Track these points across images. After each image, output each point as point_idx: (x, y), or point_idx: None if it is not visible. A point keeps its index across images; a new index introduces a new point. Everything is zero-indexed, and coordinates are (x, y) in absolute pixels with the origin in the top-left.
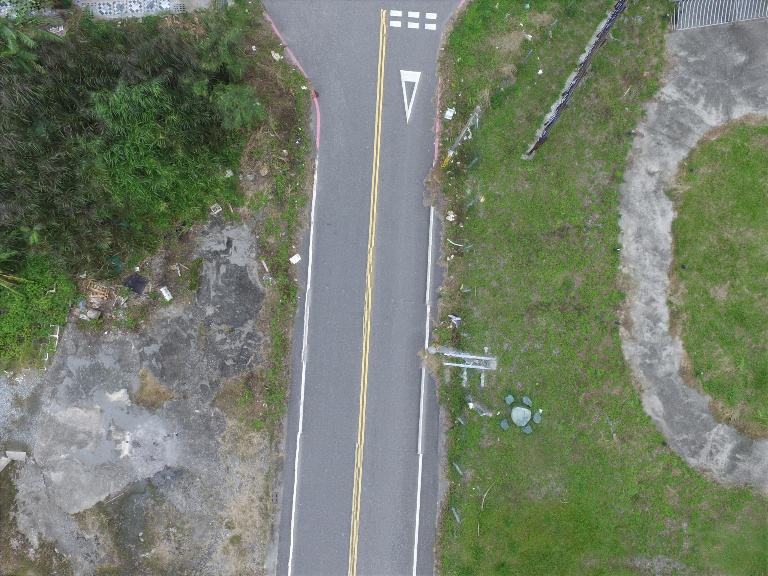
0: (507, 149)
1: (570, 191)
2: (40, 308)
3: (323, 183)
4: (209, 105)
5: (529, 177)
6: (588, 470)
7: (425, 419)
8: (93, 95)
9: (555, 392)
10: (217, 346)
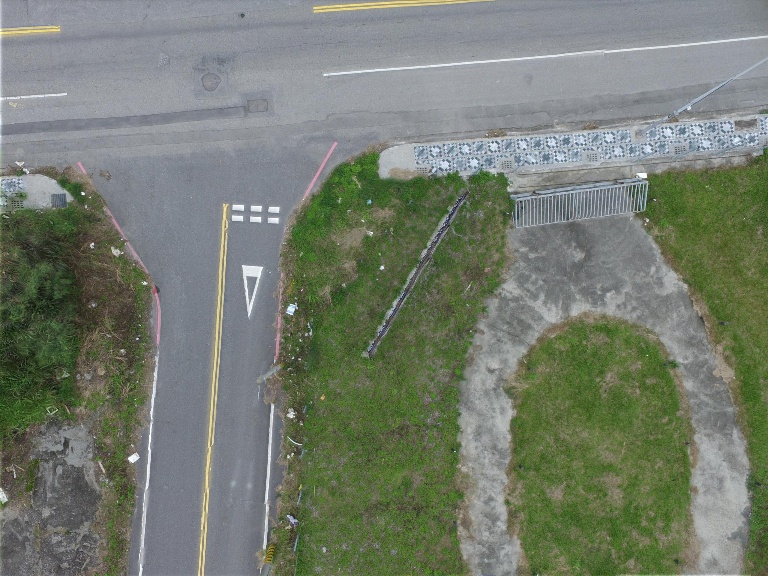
0: (348, 346)
1: (410, 389)
2: None
3: (163, 380)
4: (31, 323)
5: (369, 374)
6: None
7: None
8: None
9: None
10: (52, 549)
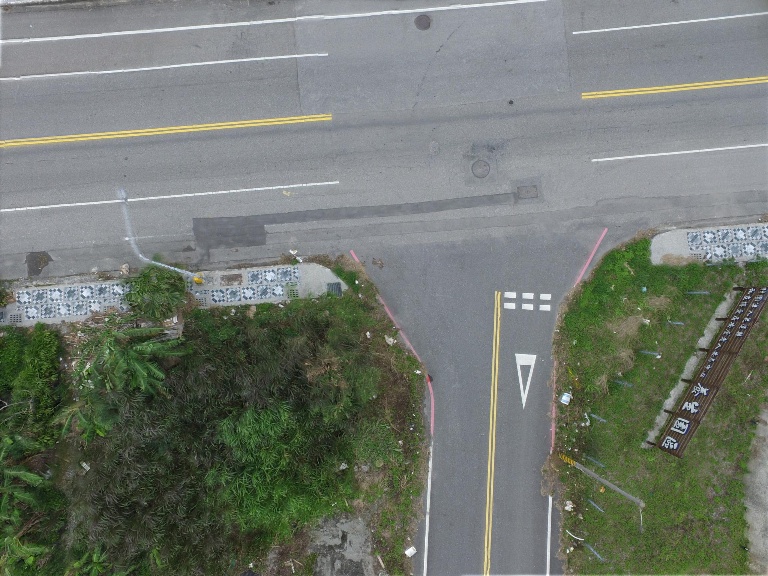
0: (626, 437)
1: (693, 482)
2: None
3: (438, 471)
4: (334, 421)
5: (650, 466)
6: None
7: None
8: (221, 425)
9: None
10: None
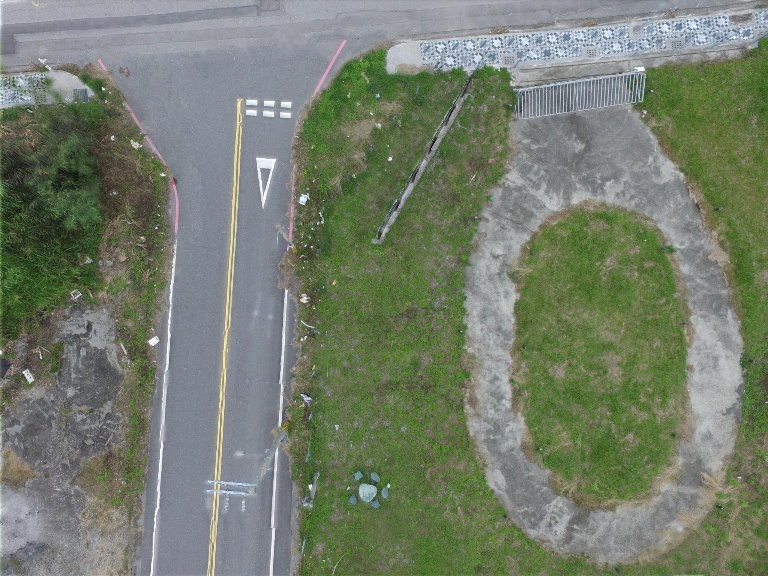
0: (358, 234)
1: (417, 274)
2: None
3: (181, 267)
4: (57, 202)
5: (379, 261)
6: (434, 542)
7: (278, 494)
8: None
9: (403, 467)
10: (77, 426)
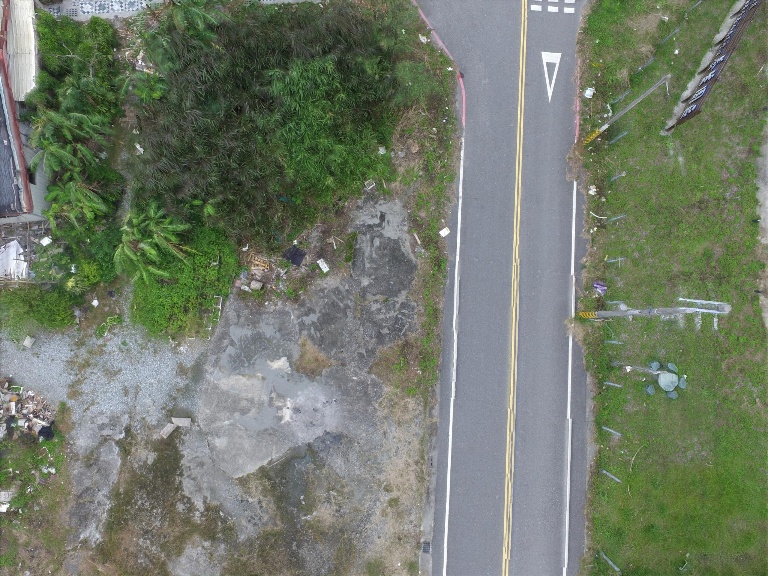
0: (646, 126)
1: (709, 165)
2: (207, 279)
3: (470, 159)
4: (375, 83)
5: (668, 152)
6: (733, 434)
7: (573, 385)
8: (272, 73)
9: (698, 358)
10: (372, 316)
